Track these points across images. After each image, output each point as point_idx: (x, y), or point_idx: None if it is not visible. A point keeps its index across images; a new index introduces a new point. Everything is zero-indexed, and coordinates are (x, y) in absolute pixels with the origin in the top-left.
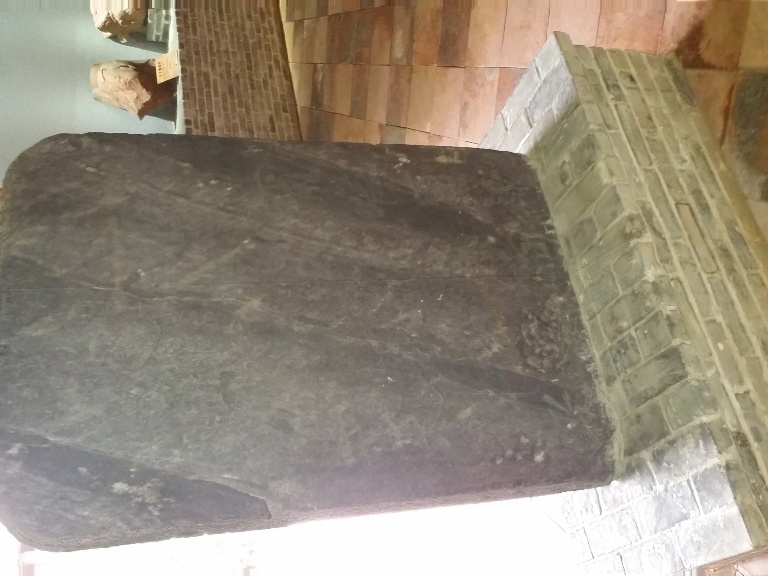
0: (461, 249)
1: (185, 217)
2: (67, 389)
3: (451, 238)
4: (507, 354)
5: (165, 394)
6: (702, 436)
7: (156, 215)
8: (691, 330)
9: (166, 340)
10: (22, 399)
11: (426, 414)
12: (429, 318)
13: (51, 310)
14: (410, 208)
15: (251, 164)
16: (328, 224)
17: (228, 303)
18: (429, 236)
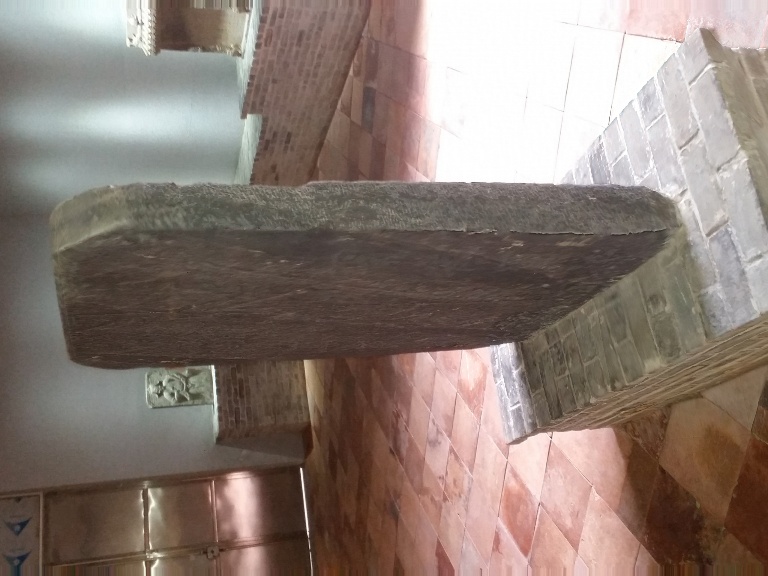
0: (507, 290)
1: (244, 280)
2: None
3: (505, 286)
4: None
5: None
6: (533, 423)
7: (215, 280)
8: None
9: None
10: None
11: None
12: None
13: (114, 321)
14: (485, 272)
15: (334, 248)
16: None
17: (266, 314)
18: (485, 285)
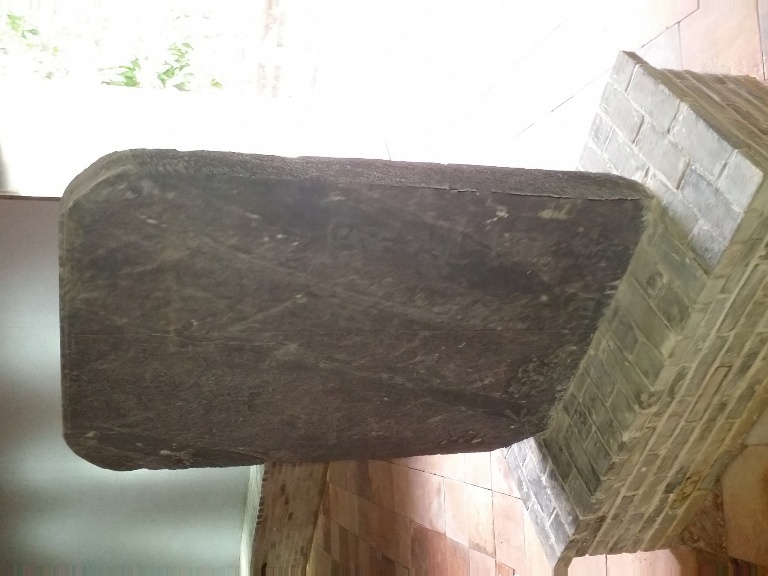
0: (507, 307)
1: (244, 272)
2: (128, 402)
3: (504, 297)
4: (495, 385)
5: (203, 405)
6: (574, 518)
7: (215, 270)
8: (629, 461)
9: (209, 372)
10: (94, 408)
11: (404, 419)
12: (442, 360)
13: (114, 351)
14: (479, 267)
15: (327, 215)
16: (386, 281)
17: (268, 346)
18: (483, 294)
